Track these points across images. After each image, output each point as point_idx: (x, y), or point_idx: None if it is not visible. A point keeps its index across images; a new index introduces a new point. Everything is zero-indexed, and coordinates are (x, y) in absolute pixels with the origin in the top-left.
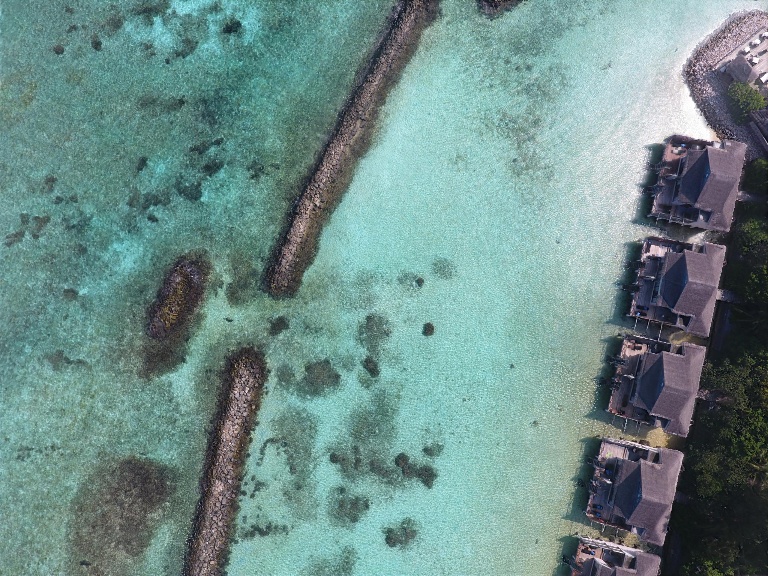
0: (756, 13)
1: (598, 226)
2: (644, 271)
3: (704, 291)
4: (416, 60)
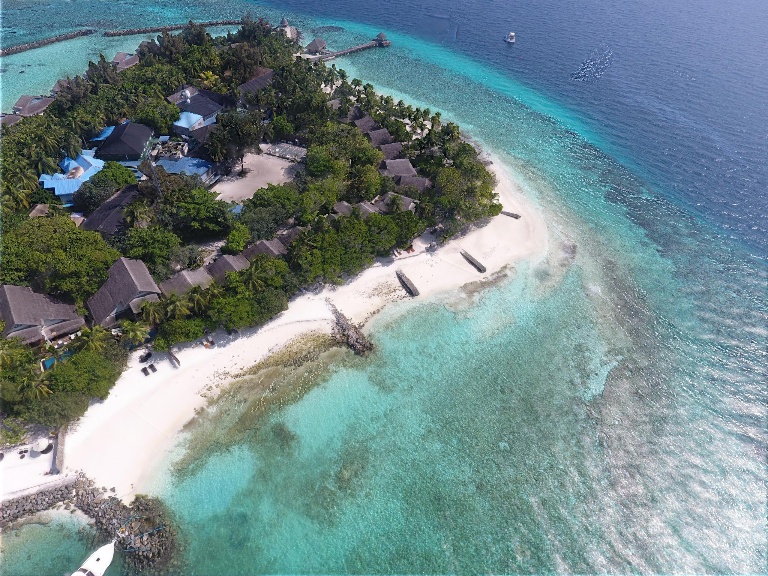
0: None
1: None
2: None
3: (123, 54)
4: None
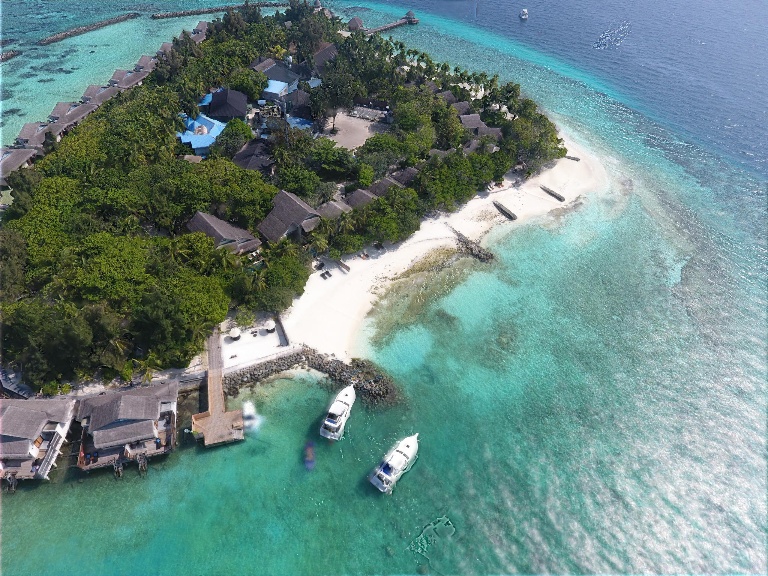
0: None
1: (171, 42)
2: None
3: (188, 33)
4: (123, 22)
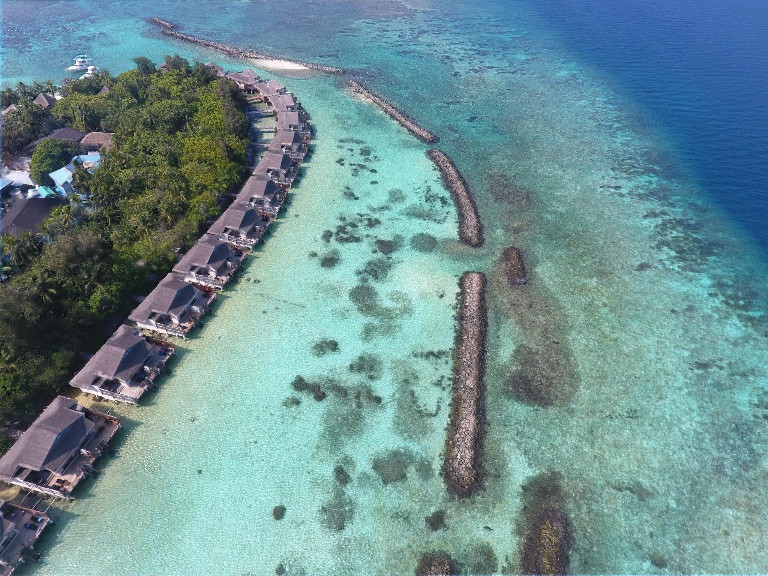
0: None
1: None
2: (3, 575)
3: None
4: None
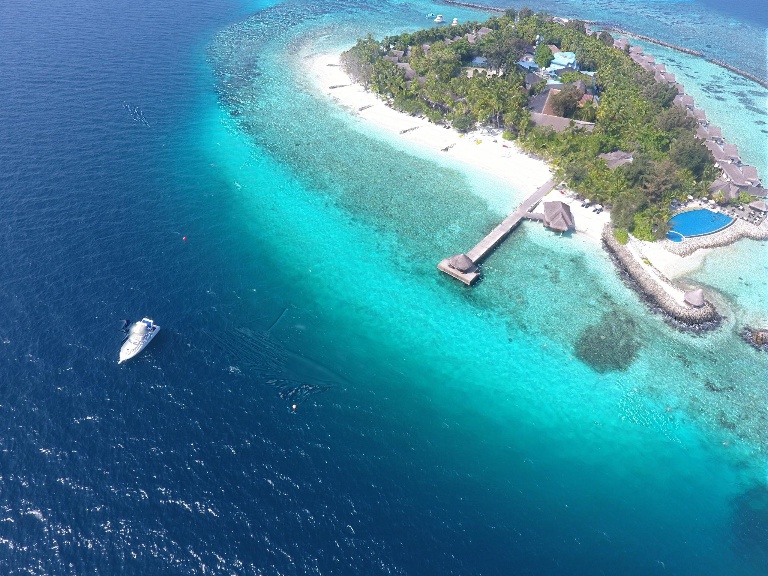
0: (761, 237)
1: None
2: None
3: None
4: None
